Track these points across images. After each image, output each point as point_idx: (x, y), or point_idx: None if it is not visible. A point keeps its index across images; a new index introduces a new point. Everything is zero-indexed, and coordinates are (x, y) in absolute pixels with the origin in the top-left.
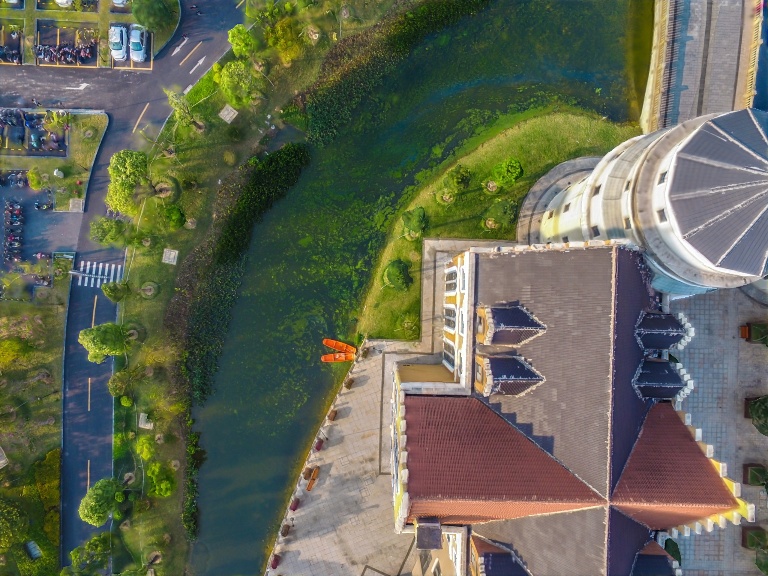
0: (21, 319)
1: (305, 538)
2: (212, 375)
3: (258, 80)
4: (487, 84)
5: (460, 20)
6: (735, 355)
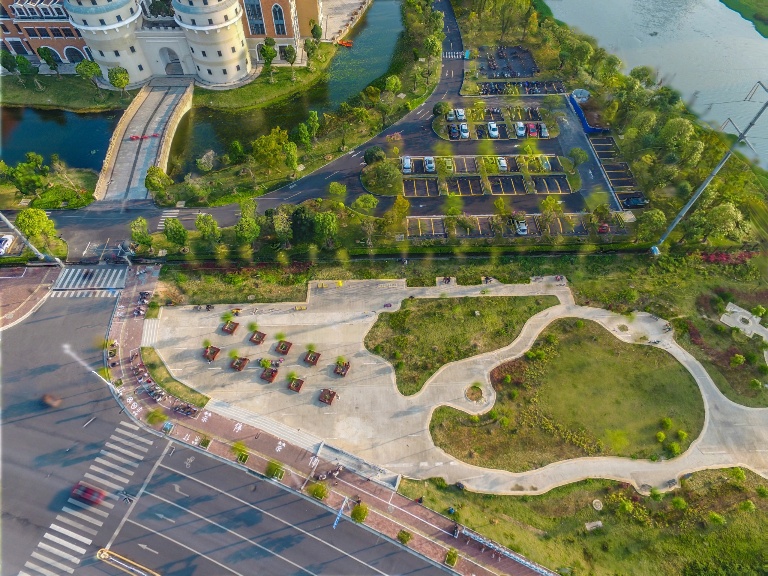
0: (471, 25)
1: None
2: None
3: None
4: None
5: None
6: None
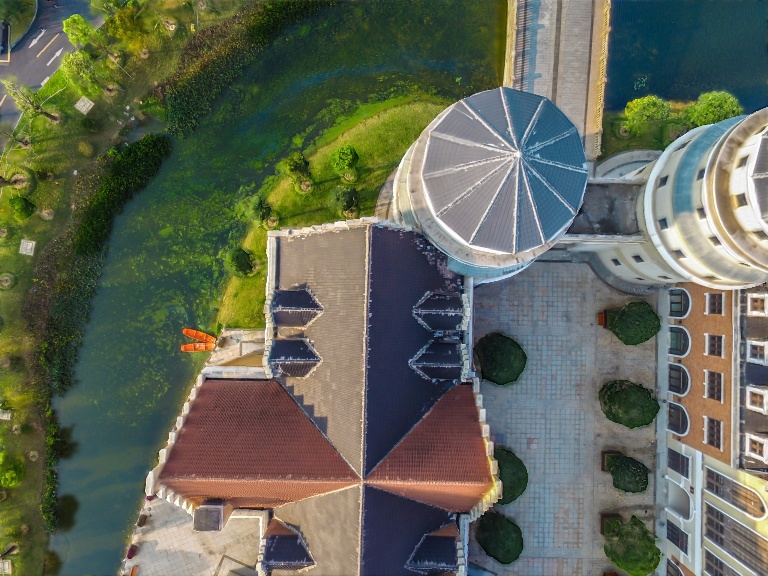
0: None
1: (162, 528)
2: (72, 366)
3: (114, 71)
4: (347, 74)
5: (320, 11)
6: (593, 342)
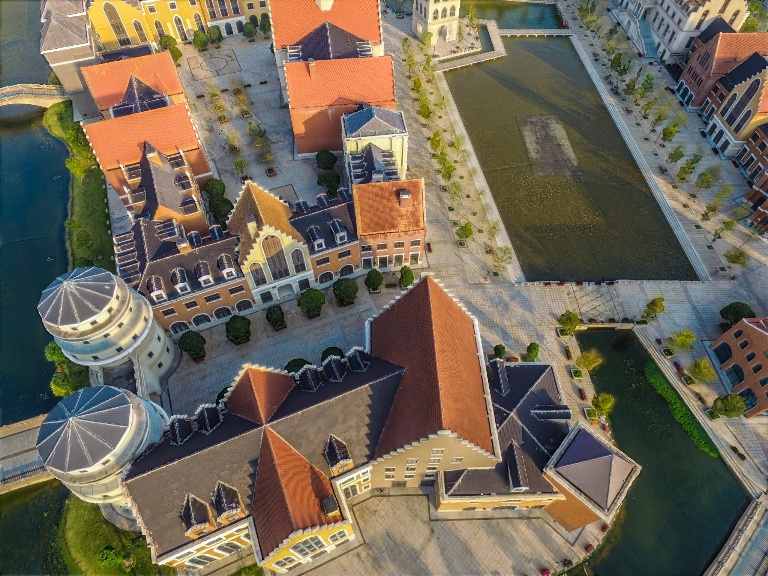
0: None
1: None
2: None
3: None
4: None
5: None
6: (215, 359)
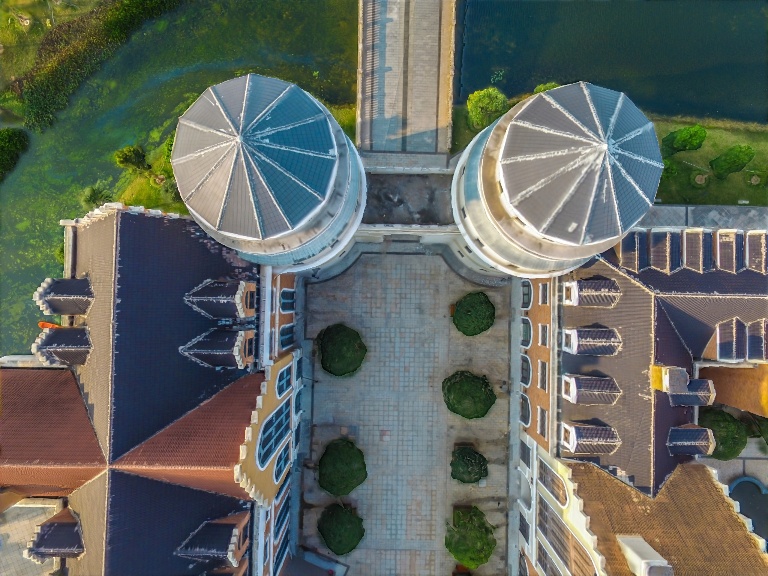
0: None
1: (14, 521)
2: None
3: None
4: (205, 68)
5: (178, 6)
6: (446, 334)
